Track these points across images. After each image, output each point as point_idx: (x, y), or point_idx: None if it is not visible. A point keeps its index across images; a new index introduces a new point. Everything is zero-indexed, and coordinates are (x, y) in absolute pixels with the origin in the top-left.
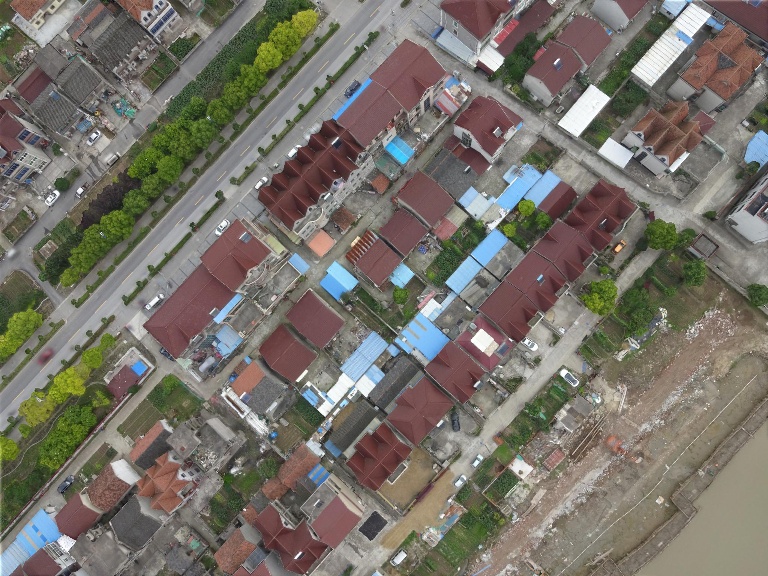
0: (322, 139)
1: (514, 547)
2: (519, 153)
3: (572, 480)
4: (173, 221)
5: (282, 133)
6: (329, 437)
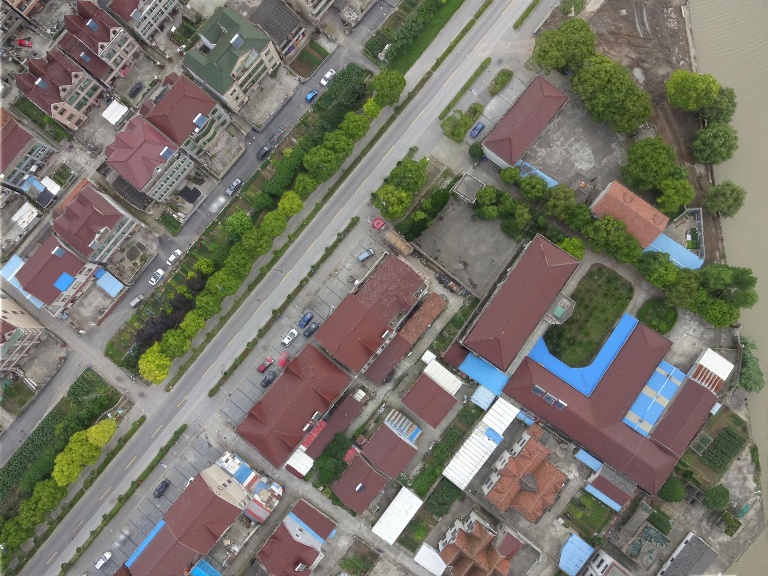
0: None
1: None
2: (336, 556)
3: None
4: None
5: (89, 540)
6: None
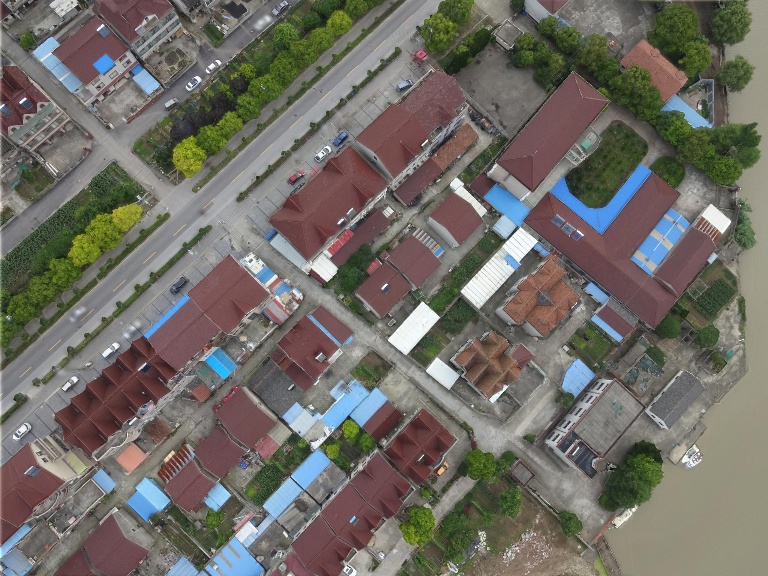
0: (131, 358)
1: None
2: (349, 365)
3: None
4: None
5: (98, 329)
6: None
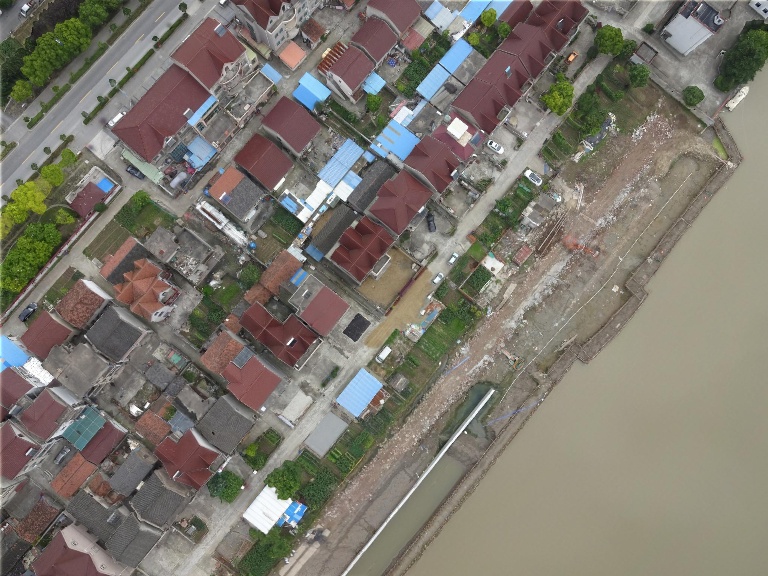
0: None
1: (490, 339)
2: None
3: (539, 273)
4: (133, 38)
5: None
6: (309, 244)
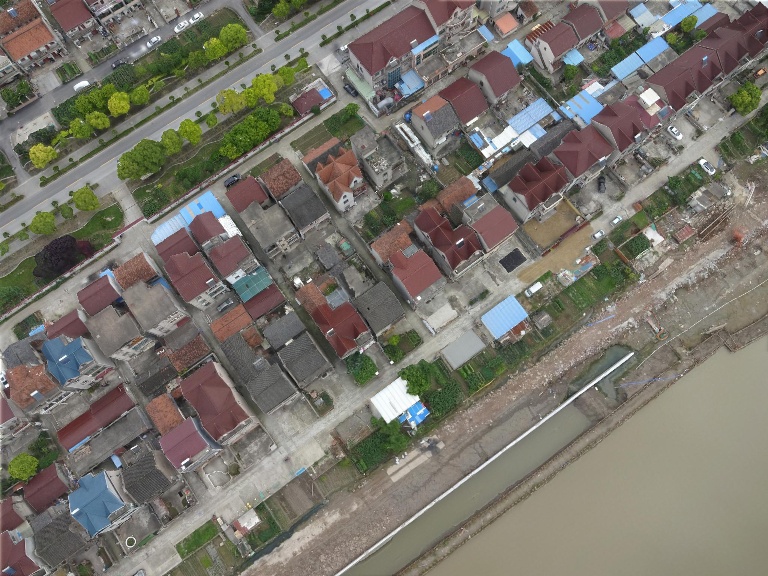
0: None
1: (638, 303)
2: None
3: (698, 255)
4: None
5: None
6: None
